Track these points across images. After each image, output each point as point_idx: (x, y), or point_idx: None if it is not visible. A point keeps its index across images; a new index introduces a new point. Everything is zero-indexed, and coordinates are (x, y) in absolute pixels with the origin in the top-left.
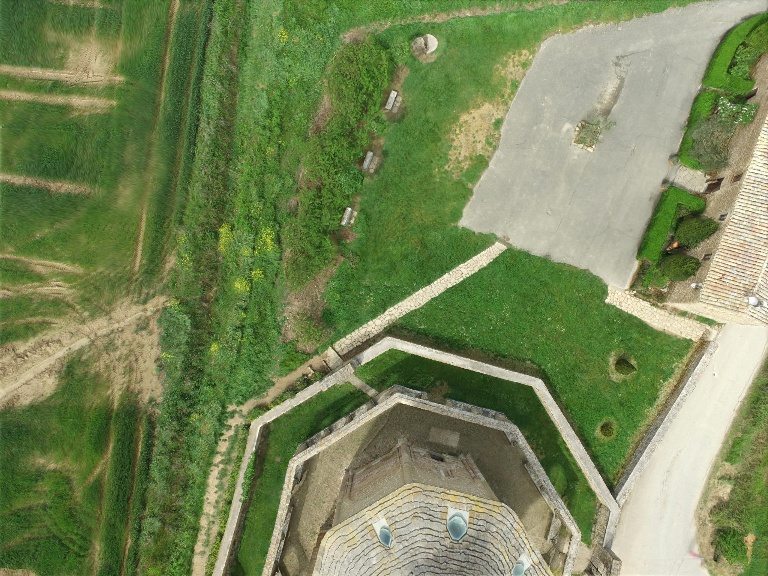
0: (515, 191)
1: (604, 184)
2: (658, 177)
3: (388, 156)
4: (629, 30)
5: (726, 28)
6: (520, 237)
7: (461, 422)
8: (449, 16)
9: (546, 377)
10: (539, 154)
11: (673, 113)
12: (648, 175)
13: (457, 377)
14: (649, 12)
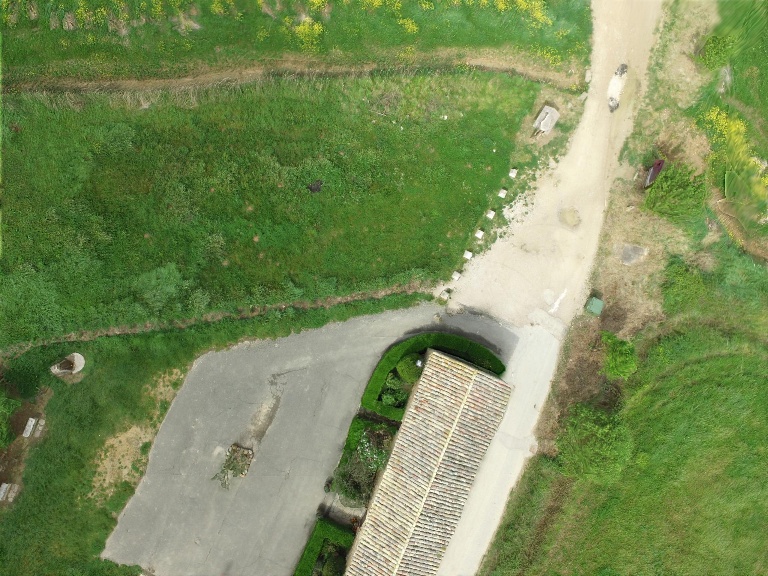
0: (162, 520)
1: (256, 511)
2: (314, 502)
3: (28, 484)
4: (286, 346)
5: (388, 343)
6: (166, 569)
7: None
8: (96, 334)
9: None
10: (188, 480)
11: (331, 434)
12: (303, 500)
13: None
14: (307, 328)
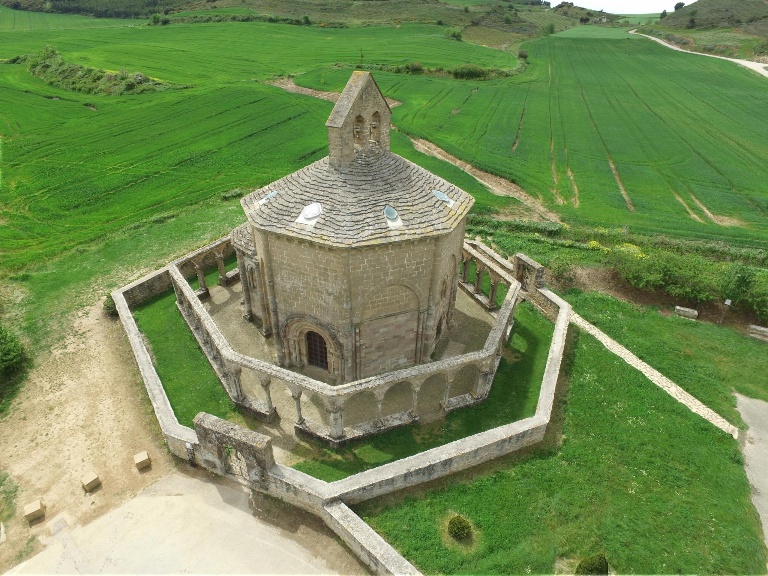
0: None
1: None
2: None
3: None
4: None
5: None
6: (765, 457)
7: (471, 367)
8: None
9: (545, 454)
10: None
11: None
12: None
13: (528, 368)
14: None
